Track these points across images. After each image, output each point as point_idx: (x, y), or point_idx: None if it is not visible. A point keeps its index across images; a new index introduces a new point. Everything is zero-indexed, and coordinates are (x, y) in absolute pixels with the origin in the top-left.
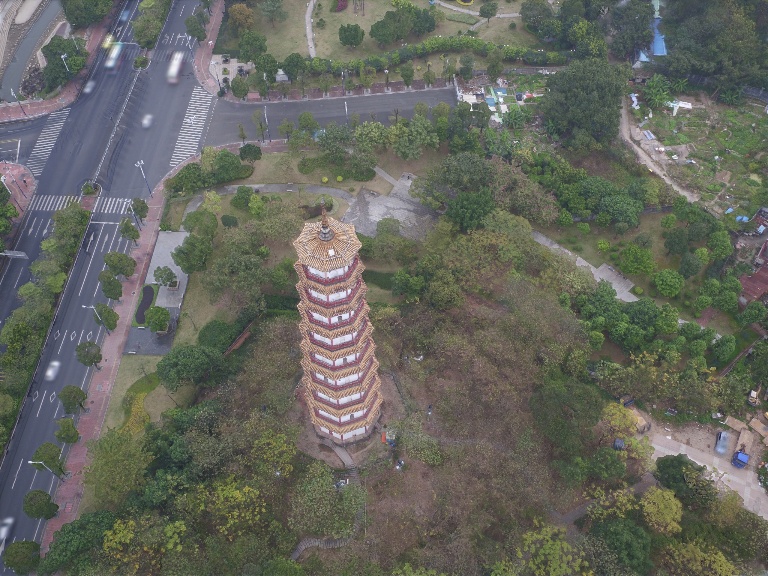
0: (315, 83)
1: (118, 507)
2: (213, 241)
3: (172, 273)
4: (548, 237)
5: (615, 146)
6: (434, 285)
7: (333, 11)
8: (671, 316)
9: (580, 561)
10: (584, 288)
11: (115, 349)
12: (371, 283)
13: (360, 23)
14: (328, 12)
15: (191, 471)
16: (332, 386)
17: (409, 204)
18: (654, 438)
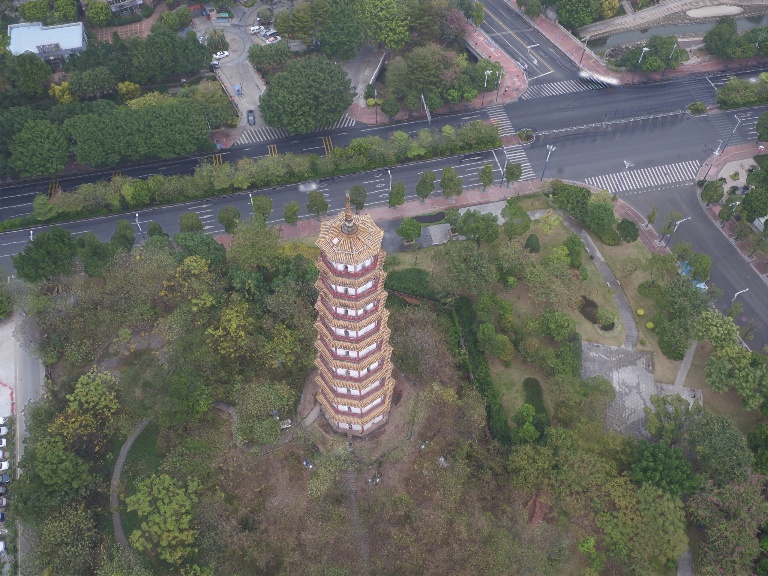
0: None
1: None
2: None
3: None
4: None
5: None
6: (526, 447)
7: None
8: None
9: None
10: None
11: (378, 216)
12: (526, 395)
13: None
14: None
15: None
16: None
17: None
18: None
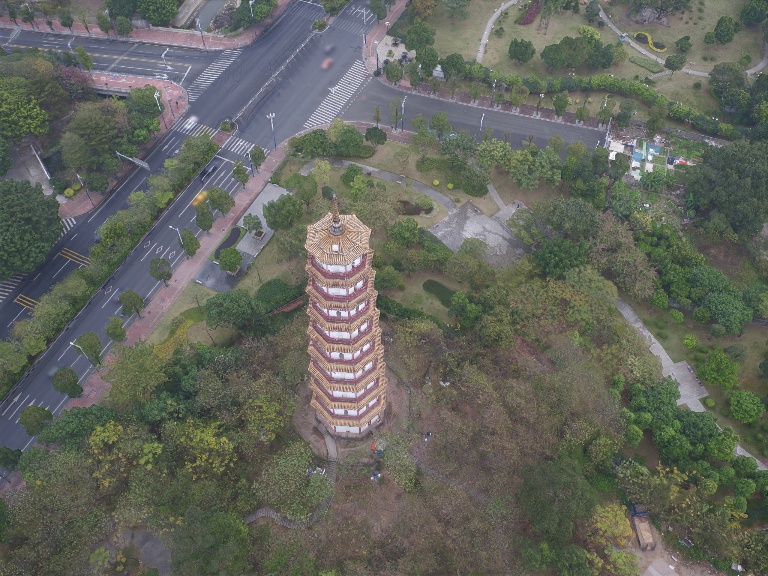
0: (469, 88)
1: (124, 410)
2: (309, 207)
3: (260, 223)
4: (636, 313)
5: (756, 243)
6: (487, 318)
7: (517, 23)
8: (727, 442)
9: None
10: (644, 378)
11: (187, 274)
12: (435, 295)
13: (538, 41)
14: (512, 23)
15: (193, 404)
16: (327, 376)
17: (507, 232)
18: (655, 561)
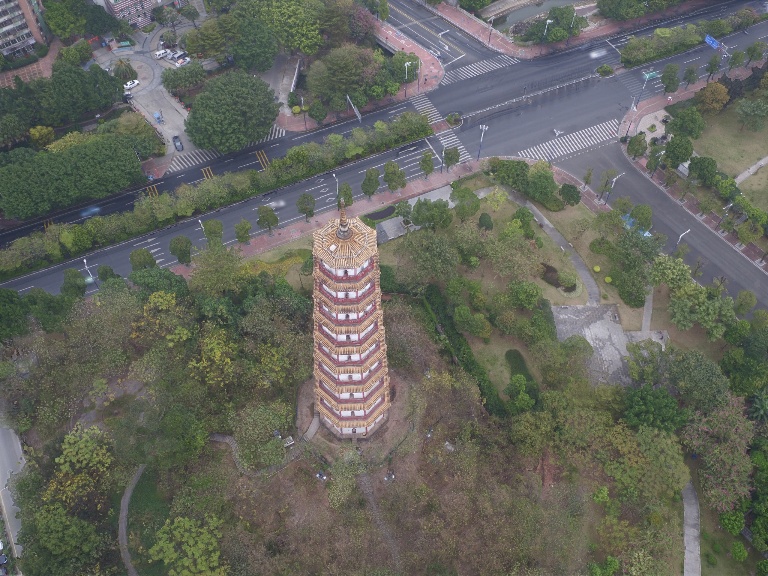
0: None
1: None
2: None
3: (410, 213)
4: (701, 518)
5: None
6: (526, 416)
7: None
8: None
9: None
10: None
11: None
12: (510, 367)
13: None
14: None
15: None
16: (318, 362)
17: (630, 355)
18: None
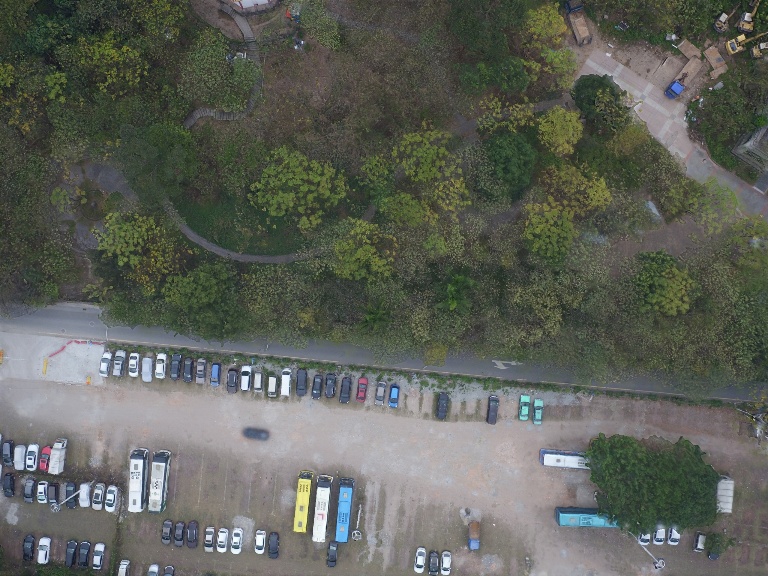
0: None
1: (7, 49)
2: None
3: None
4: None
5: None
6: None
7: None
8: None
9: (454, 167)
10: None
11: None
12: None
13: None
14: None
15: (78, 21)
16: None
17: None
18: (592, 53)
